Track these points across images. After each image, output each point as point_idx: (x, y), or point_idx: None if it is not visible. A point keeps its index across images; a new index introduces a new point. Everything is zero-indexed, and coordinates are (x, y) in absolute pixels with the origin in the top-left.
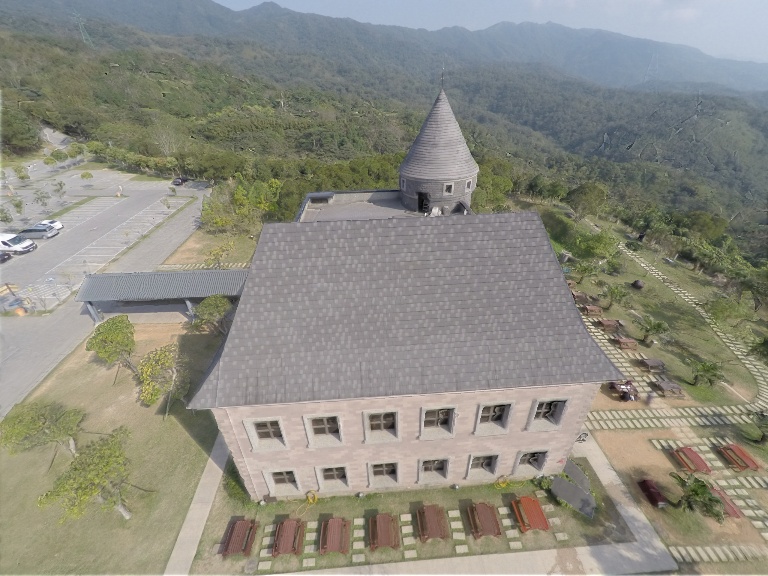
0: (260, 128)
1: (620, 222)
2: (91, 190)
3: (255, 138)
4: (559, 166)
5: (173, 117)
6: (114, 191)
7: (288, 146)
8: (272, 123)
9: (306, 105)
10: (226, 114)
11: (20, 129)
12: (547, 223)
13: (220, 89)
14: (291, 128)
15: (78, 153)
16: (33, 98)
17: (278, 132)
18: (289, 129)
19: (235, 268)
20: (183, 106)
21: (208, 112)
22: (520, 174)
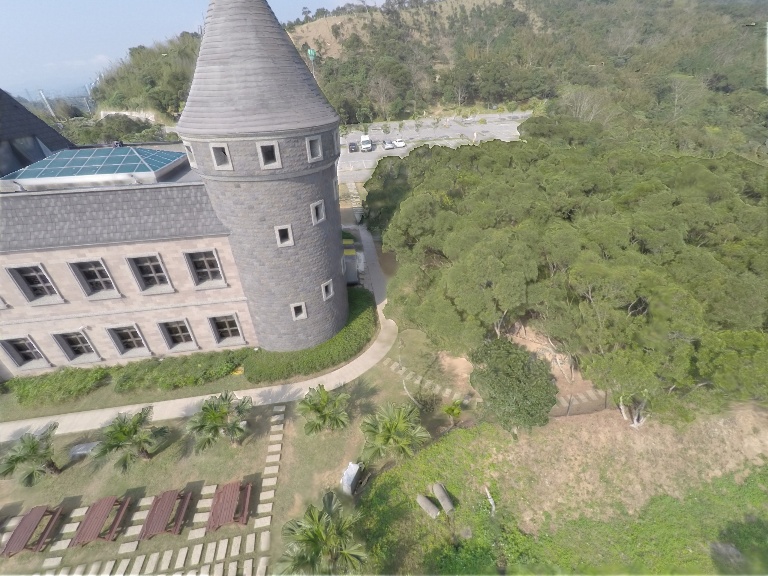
0: None
1: None
2: (478, 134)
3: None
4: None
5: (705, 87)
6: (482, 138)
7: None
8: None
9: None
10: None
11: (527, 84)
12: None
13: None
14: None
15: (531, 108)
16: (619, 64)
17: None
18: None
19: (350, 204)
20: None
21: None
22: None
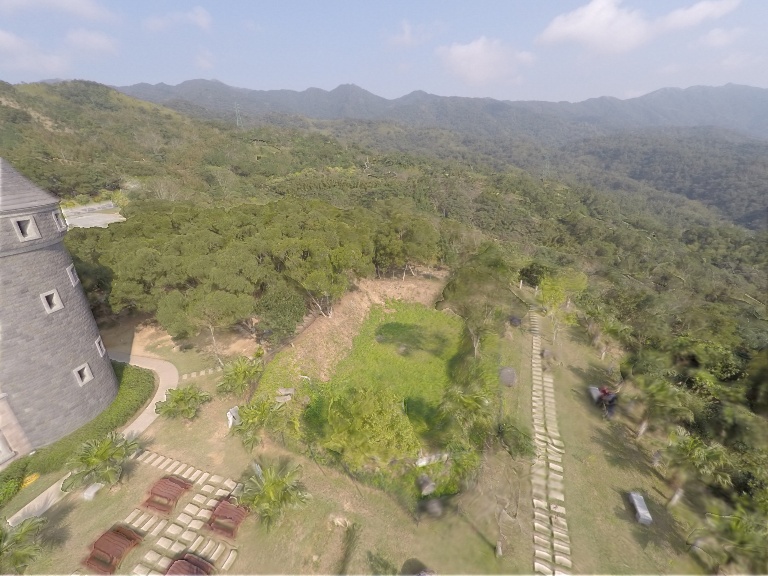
0: (328, 186)
1: (620, 354)
2: None
3: (321, 195)
4: (704, 242)
5: (233, 174)
6: None
7: (349, 203)
8: (340, 182)
9: (388, 167)
10: (304, 174)
11: (82, 179)
12: (468, 331)
13: (311, 153)
14: (358, 187)
15: (105, 199)
16: (158, 160)
17: (344, 190)
18: (356, 188)
19: None
20: (270, 167)
21: (290, 172)
22: (477, 244)
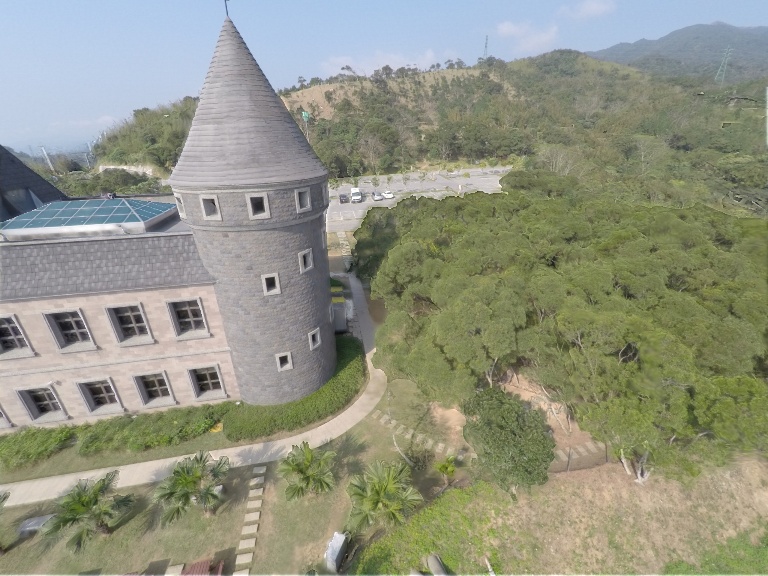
0: None
1: None
2: (463, 187)
3: None
4: None
5: (667, 146)
6: (467, 190)
7: None
8: None
9: None
10: None
11: (505, 143)
12: None
13: None
14: None
15: (511, 163)
16: (587, 126)
17: None
18: None
19: (340, 253)
20: (740, 139)
21: None
22: None
